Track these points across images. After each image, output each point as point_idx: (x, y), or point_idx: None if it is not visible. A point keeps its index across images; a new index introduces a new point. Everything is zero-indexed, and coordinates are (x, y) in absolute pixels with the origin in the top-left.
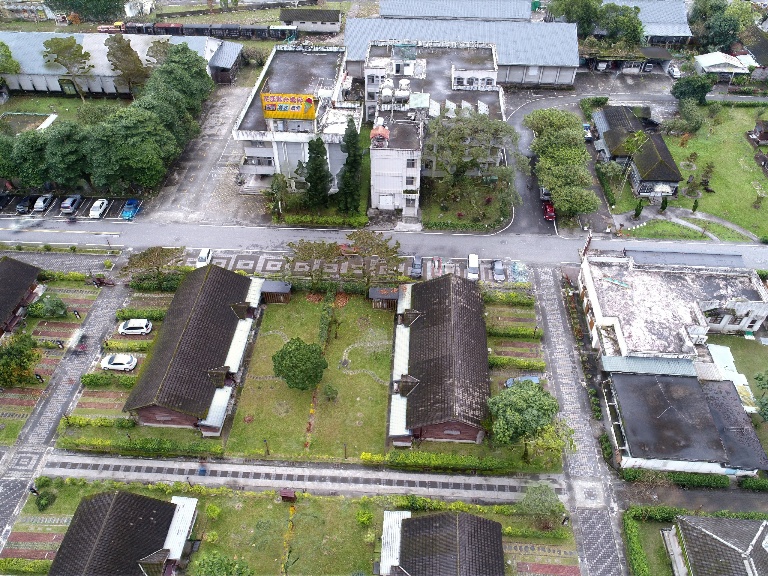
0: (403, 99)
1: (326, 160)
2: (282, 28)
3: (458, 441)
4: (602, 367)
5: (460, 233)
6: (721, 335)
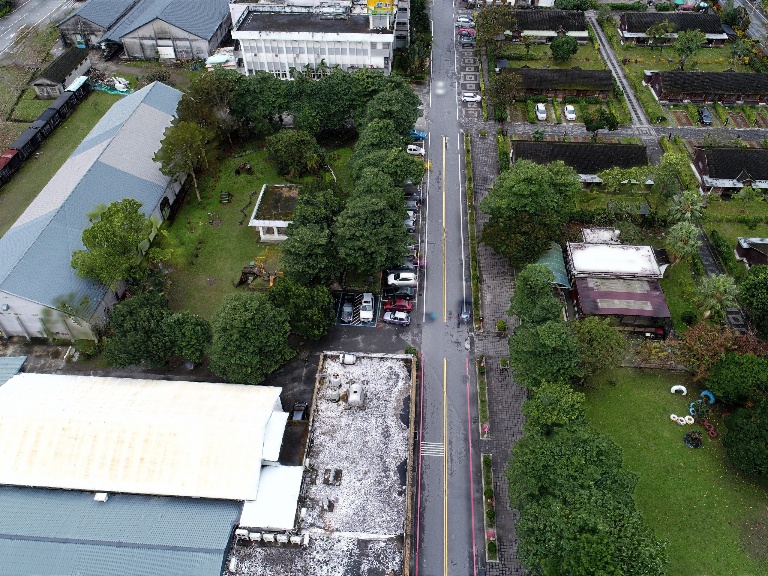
0: None
1: None
2: (80, 84)
3: None
4: (524, 5)
5: None
6: None
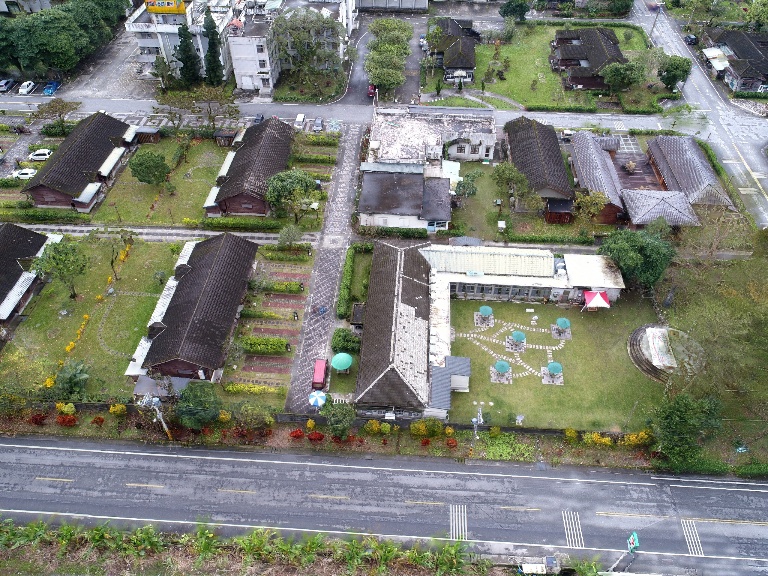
0: (263, 5)
1: (192, 43)
2: None
3: (253, 215)
4: None
5: (300, 104)
6: (466, 162)
